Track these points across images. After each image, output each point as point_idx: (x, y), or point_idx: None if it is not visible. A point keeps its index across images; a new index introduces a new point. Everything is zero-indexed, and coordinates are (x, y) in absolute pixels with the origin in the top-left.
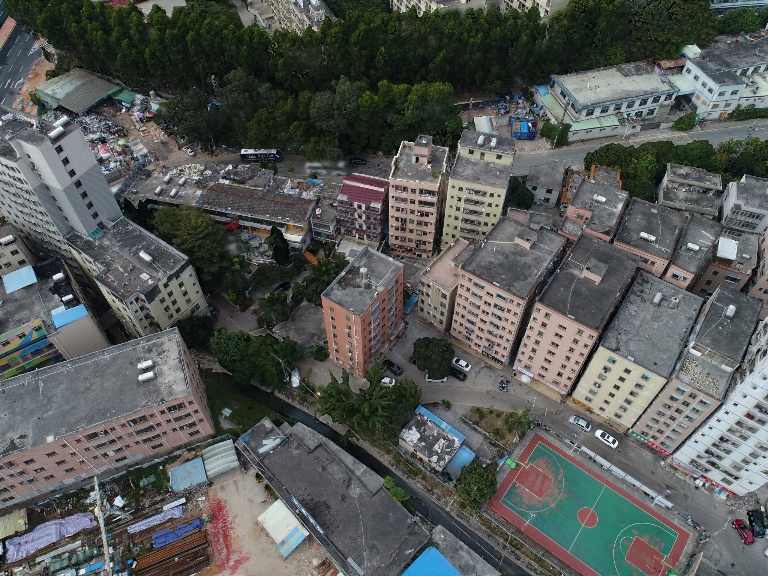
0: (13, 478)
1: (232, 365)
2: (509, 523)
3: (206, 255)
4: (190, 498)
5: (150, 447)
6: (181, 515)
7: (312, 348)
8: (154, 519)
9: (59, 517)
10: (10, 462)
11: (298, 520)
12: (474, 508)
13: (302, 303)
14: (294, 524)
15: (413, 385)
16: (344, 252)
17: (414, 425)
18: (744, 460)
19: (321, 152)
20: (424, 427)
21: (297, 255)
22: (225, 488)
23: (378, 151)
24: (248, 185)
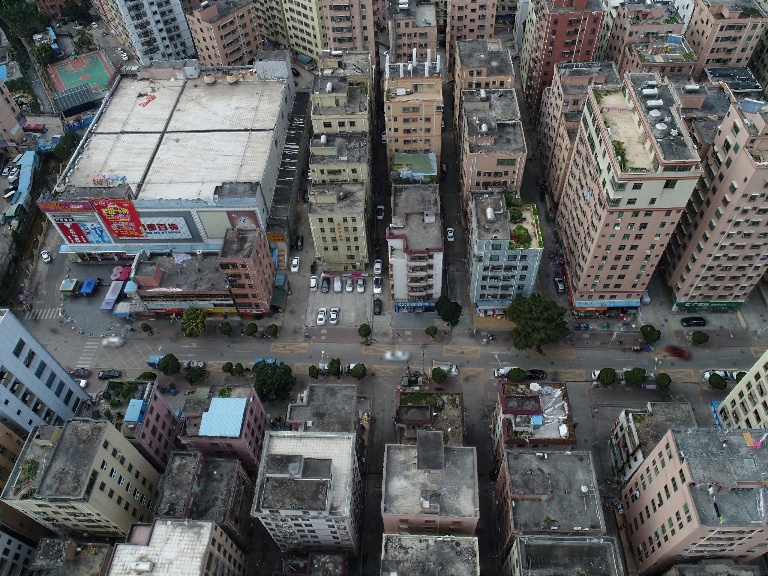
0: None
1: None
2: None
3: None
4: None
5: None
6: None
7: None
8: None
9: None
10: None
11: None
12: (37, 61)
13: None
14: None
15: (49, 15)
16: None
17: None
18: (131, 40)
19: None
20: (46, 35)
21: None
22: None
23: None
24: None
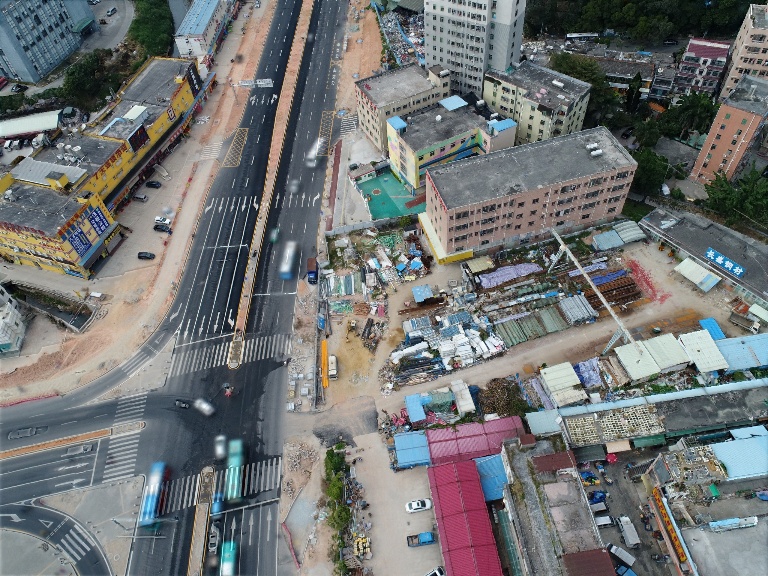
0: (503, 219)
1: None
2: None
3: (598, 87)
4: (609, 258)
5: (582, 216)
6: (606, 268)
7: (676, 167)
8: (587, 268)
9: (511, 265)
10: (512, 201)
11: (709, 271)
12: None
13: None
14: (706, 273)
15: None
16: (679, 105)
17: None
18: None
19: (650, 29)
20: None
21: (644, 104)
22: (634, 254)
23: (688, 34)
24: (590, 54)
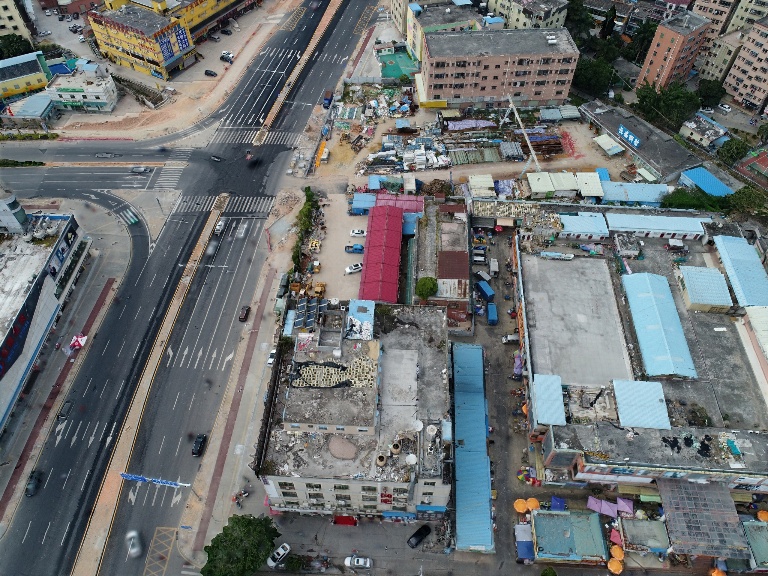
0: (472, 78)
1: (579, 71)
2: (753, 169)
3: (575, 7)
4: (549, 128)
5: (535, 92)
6: (544, 132)
7: (625, 80)
8: (530, 130)
9: (474, 119)
10: (480, 62)
11: (618, 143)
12: (729, 161)
13: (619, 59)
14: (616, 144)
15: None
16: None
17: (693, 121)
18: None
19: None
20: (700, 123)
21: (617, 35)
22: (569, 128)
23: None
24: None
